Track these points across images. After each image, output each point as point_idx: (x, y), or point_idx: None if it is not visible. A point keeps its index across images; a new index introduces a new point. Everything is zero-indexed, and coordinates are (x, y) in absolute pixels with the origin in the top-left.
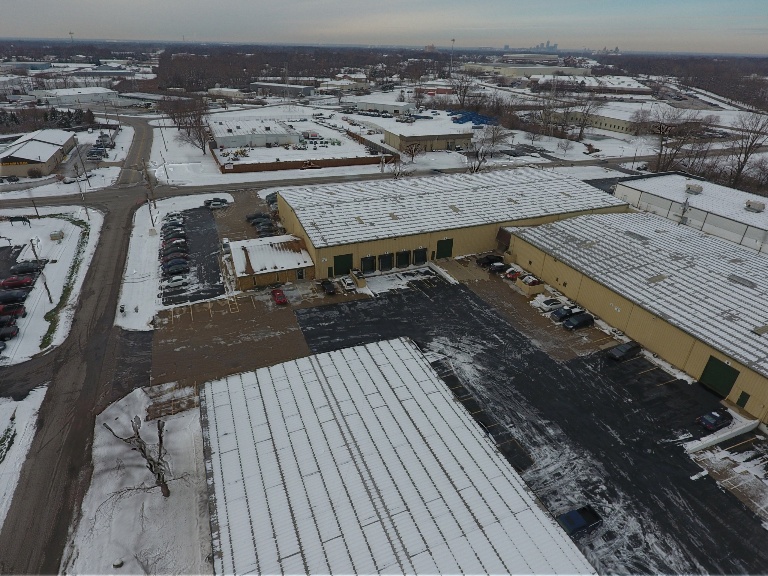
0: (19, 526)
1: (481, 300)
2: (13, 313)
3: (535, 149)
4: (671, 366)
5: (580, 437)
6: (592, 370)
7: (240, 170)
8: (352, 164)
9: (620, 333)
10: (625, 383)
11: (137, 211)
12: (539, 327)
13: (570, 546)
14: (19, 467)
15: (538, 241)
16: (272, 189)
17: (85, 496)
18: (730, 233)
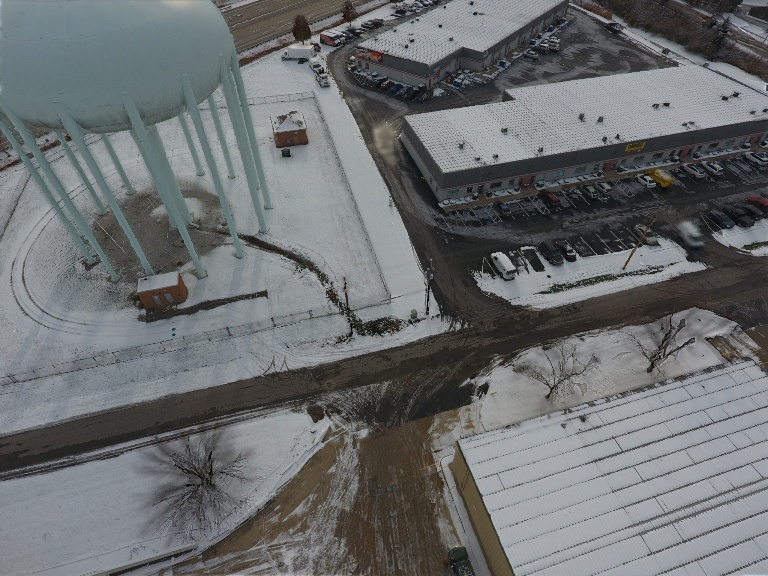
0: (604, 303)
1: None
2: None
3: None
4: None
5: None
6: None
7: None
8: None
9: None
10: None
11: None
12: None
13: None
14: (639, 285)
15: None
16: None
17: (632, 326)
18: None
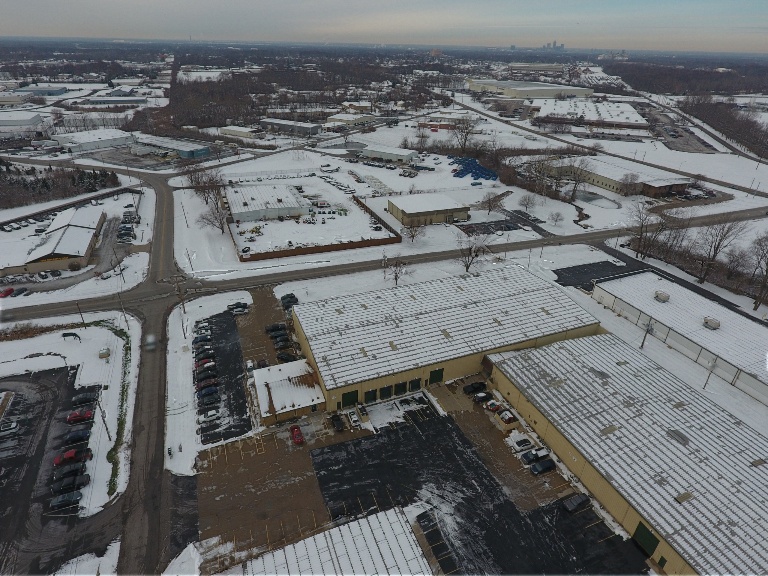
0: None
1: (465, 437)
2: (83, 457)
3: (528, 219)
4: (612, 520)
5: None
6: (549, 523)
7: (256, 258)
8: (358, 247)
9: (576, 480)
10: (573, 539)
11: (169, 318)
12: (510, 471)
13: None
14: None
15: (515, 376)
16: (286, 284)
17: None
18: (688, 350)
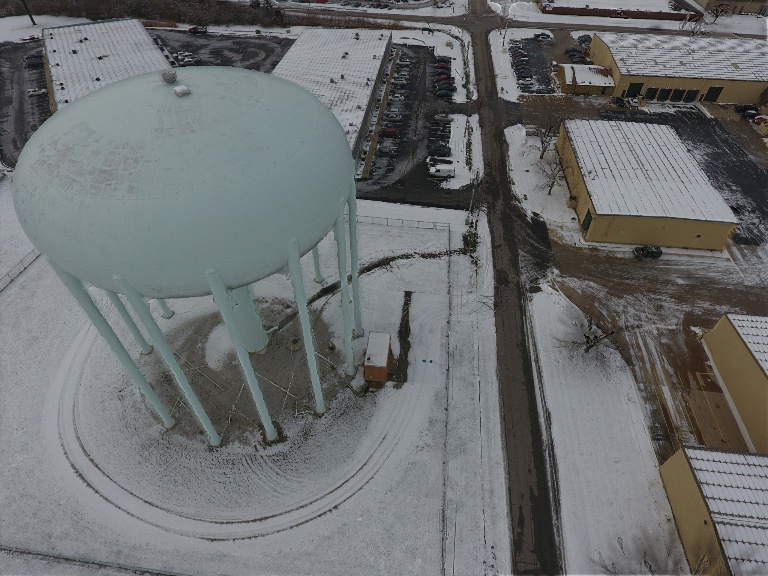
0: (488, 153)
1: (725, 130)
2: (451, 80)
3: None
4: None
5: (750, 193)
6: None
7: (557, 12)
8: (653, 18)
9: None
10: None
11: (490, 35)
12: (760, 151)
13: (719, 195)
14: (480, 137)
15: None
16: (582, 32)
17: (509, 152)
18: None
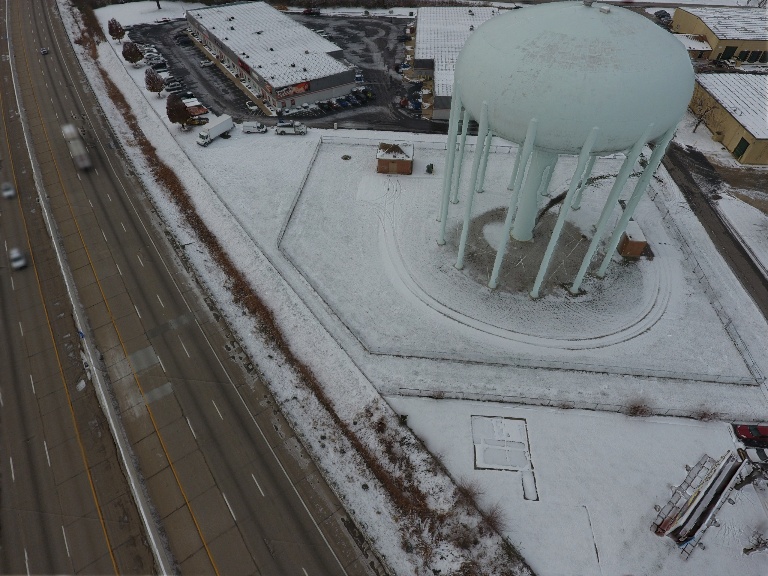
0: None
1: None
2: None
3: None
4: None
5: None
6: None
7: None
8: None
9: None
10: None
11: None
12: None
13: None
14: None
15: None
16: (654, 8)
17: None
18: None
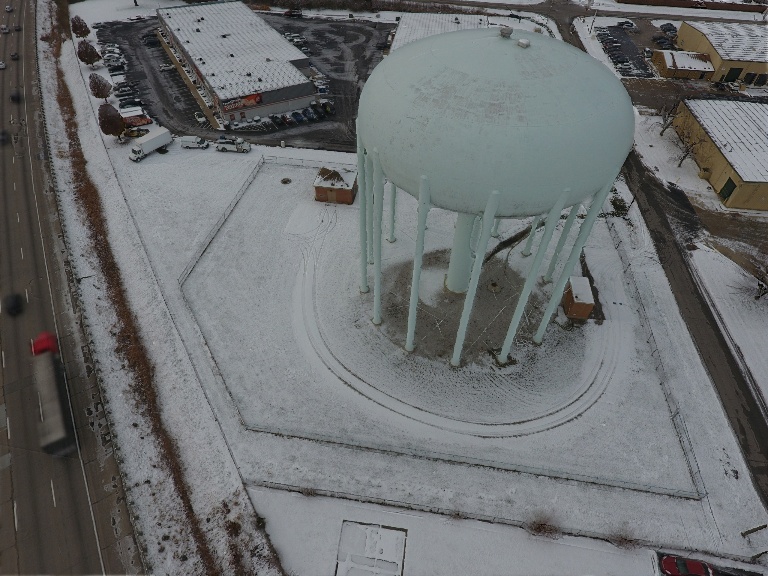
0: None
1: None
2: None
3: None
4: None
5: None
6: None
7: (632, 2)
8: (727, 9)
9: None
10: None
11: (574, 22)
12: None
13: None
14: None
15: None
16: (661, 21)
17: None
18: None
